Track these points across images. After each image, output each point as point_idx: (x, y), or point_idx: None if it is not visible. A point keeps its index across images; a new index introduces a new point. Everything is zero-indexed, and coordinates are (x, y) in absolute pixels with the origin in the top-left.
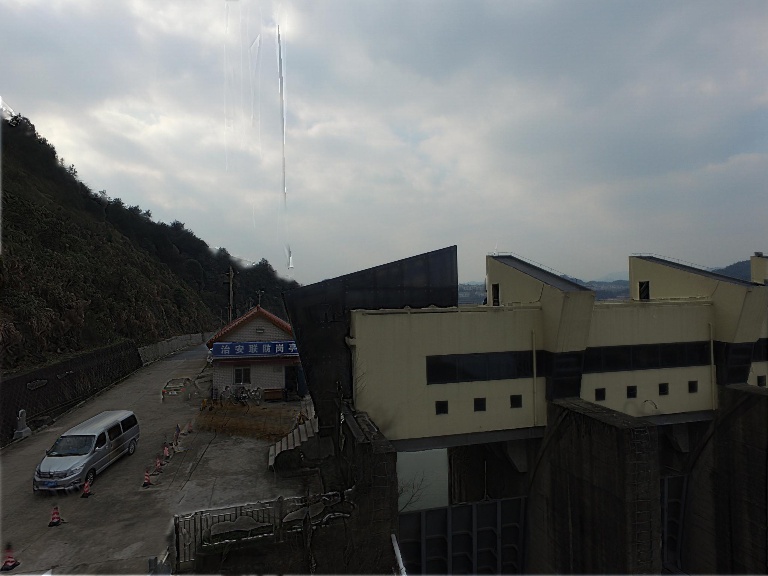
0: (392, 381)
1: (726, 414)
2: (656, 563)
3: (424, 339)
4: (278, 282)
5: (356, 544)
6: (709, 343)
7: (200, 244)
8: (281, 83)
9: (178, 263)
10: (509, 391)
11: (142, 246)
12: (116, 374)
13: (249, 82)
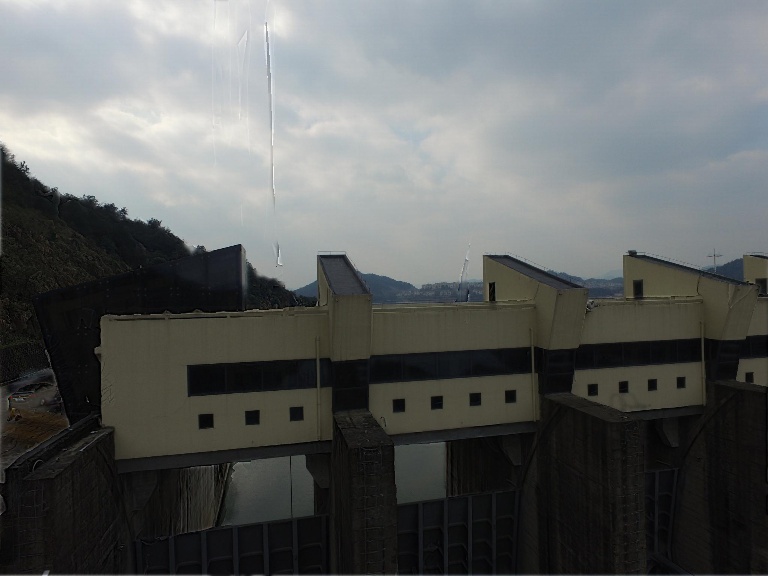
0: (146, 393)
1: (544, 426)
2: None
3: (185, 347)
4: (256, 280)
5: None
6: (530, 349)
7: (175, 242)
8: (269, 80)
9: (141, 261)
10: (289, 403)
11: (100, 244)
12: (1, 377)
13: (237, 79)
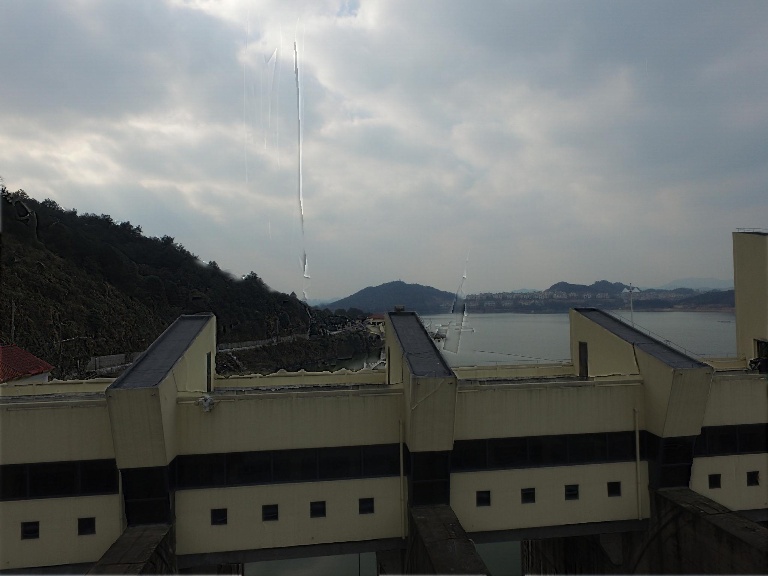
0: None
1: None
2: None
3: None
4: (263, 295)
5: None
6: None
7: (182, 258)
8: (297, 96)
9: (127, 280)
10: None
11: (83, 265)
12: None
13: None
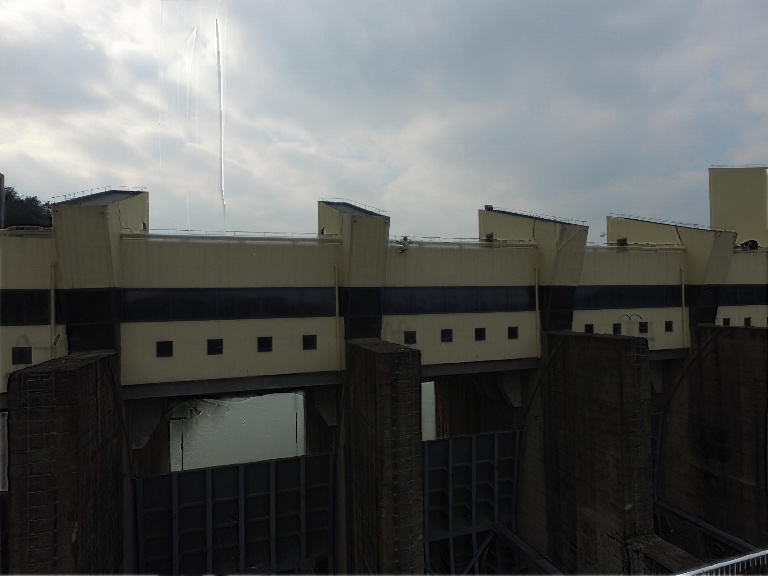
0: None
1: (347, 375)
2: (65, 564)
3: None
4: None
5: None
6: (334, 289)
7: None
8: (219, 78)
9: None
10: (12, 342)
11: None
12: None
13: None
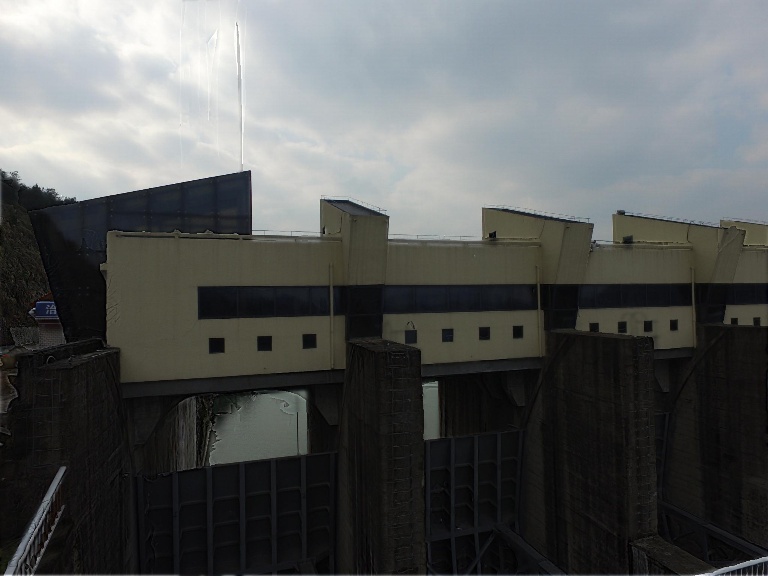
0: (154, 314)
1: (551, 360)
2: (417, 504)
3: (196, 268)
4: None
5: (10, 478)
6: (536, 286)
7: None
8: (239, 80)
9: None
10: (301, 330)
11: None
12: None
13: (206, 77)
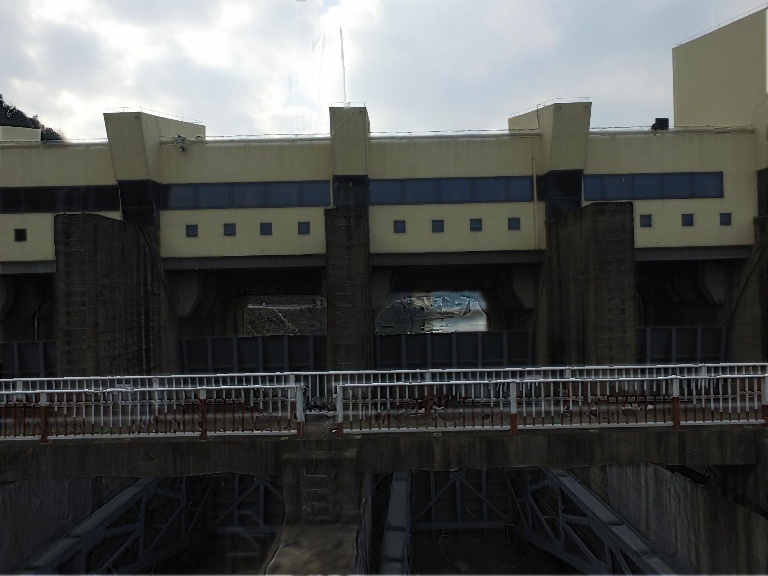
0: None
1: None
2: None
3: None
4: None
5: None
6: None
7: None
8: (343, 78)
9: None
10: None
11: None
12: None
13: None
